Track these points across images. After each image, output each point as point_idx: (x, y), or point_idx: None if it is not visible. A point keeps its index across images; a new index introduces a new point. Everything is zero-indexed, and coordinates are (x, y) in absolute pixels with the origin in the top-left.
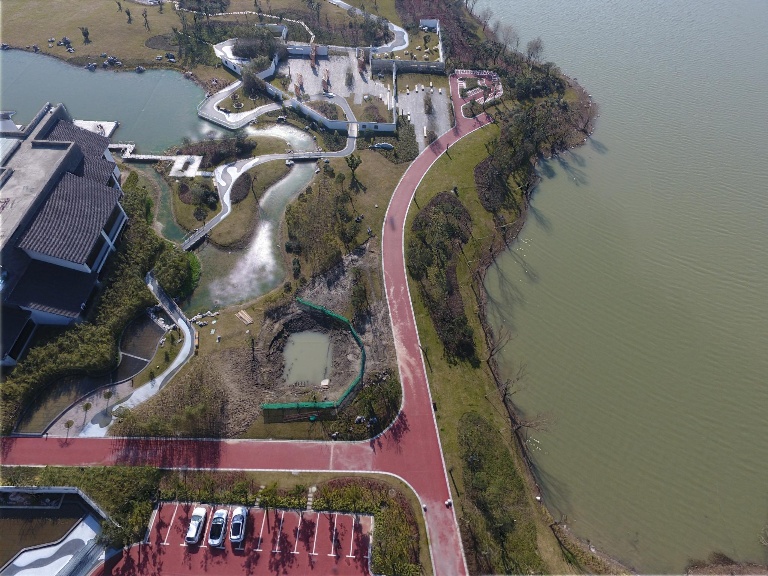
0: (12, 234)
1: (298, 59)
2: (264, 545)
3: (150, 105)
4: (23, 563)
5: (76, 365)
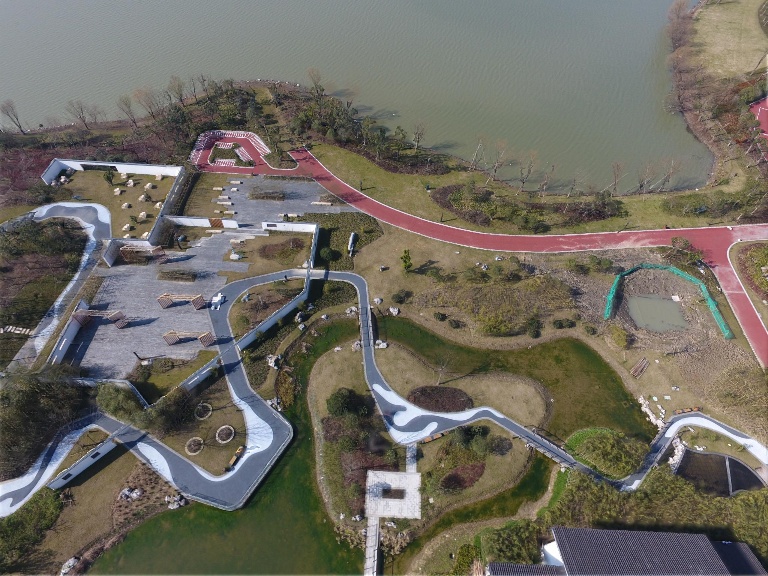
0: None
1: (87, 350)
2: None
3: None
4: None
5: None
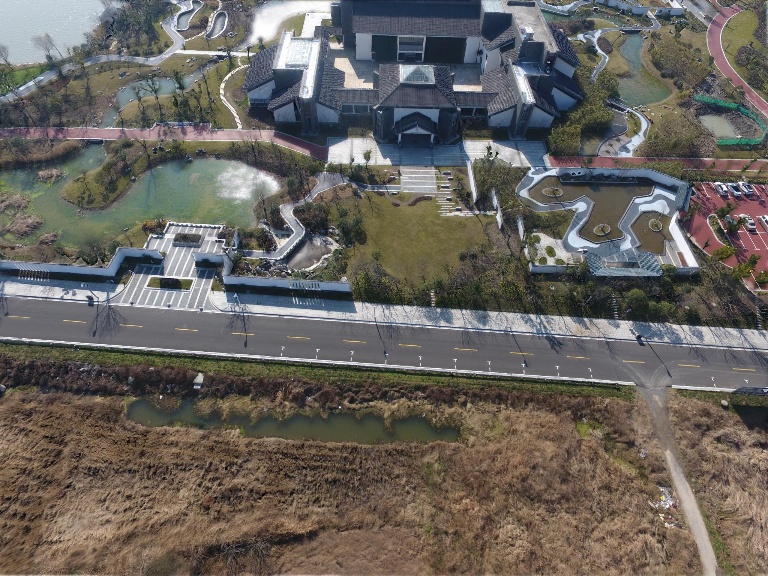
0: (555, 42)
1: None
2: (764, 197)
3: None
4: (639, 202)
5: (602, 120)
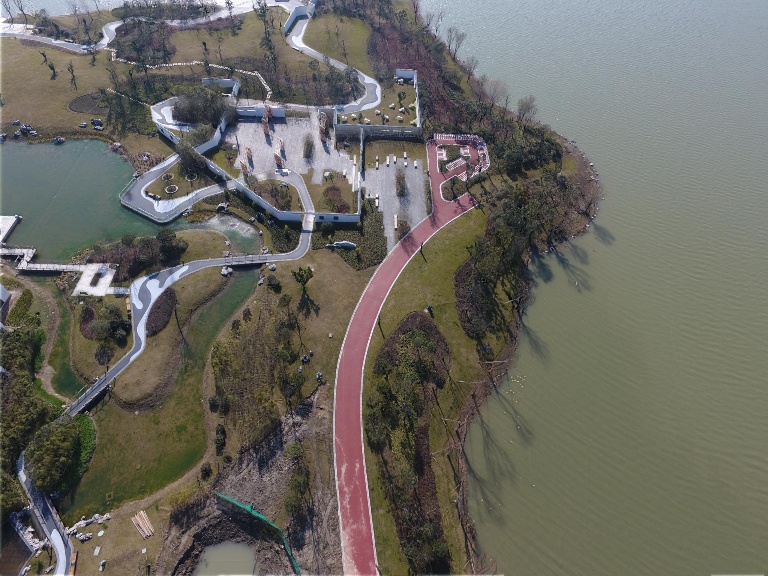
0: None
1: (250, 123)
2: None
3: (64, 189)
4: None
5: None
